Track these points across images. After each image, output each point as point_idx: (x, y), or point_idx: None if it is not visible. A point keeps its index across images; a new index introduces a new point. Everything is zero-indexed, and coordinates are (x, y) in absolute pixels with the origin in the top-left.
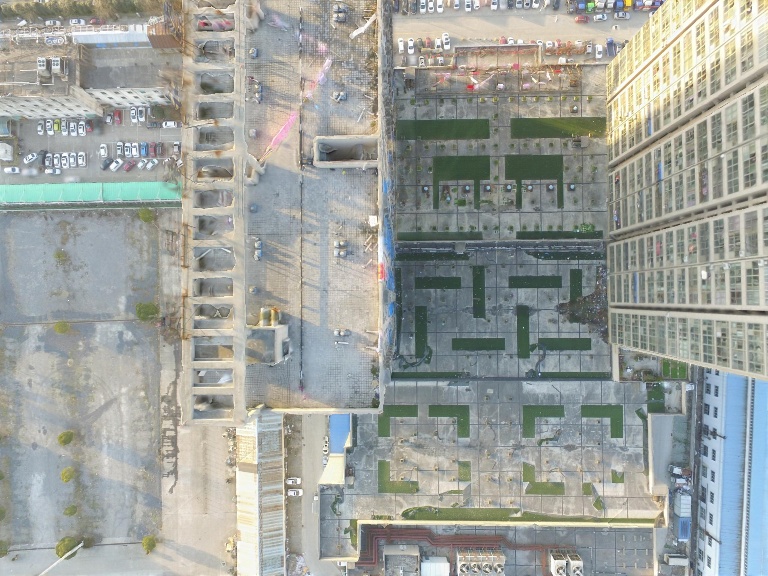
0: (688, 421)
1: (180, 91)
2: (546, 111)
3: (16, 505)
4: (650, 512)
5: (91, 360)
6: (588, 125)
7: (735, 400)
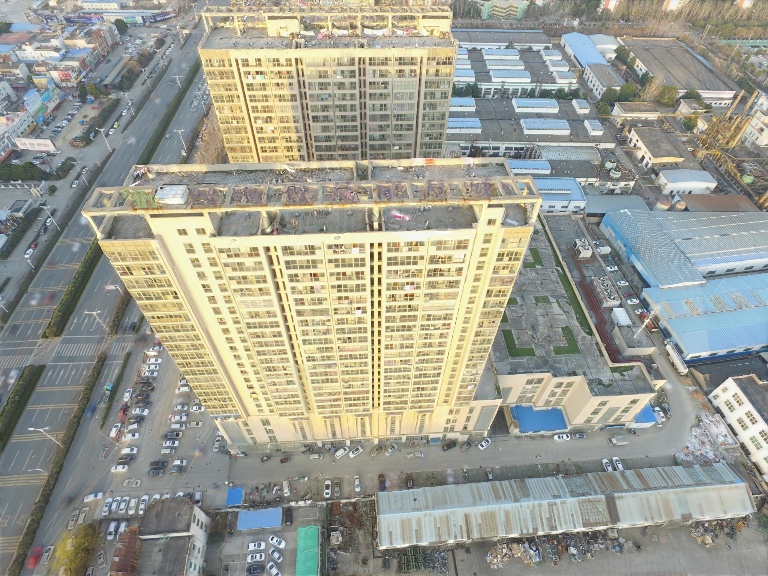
0: None
1: (338, 200)
2: None
3: None
4: None
5: None
6: None
7: None
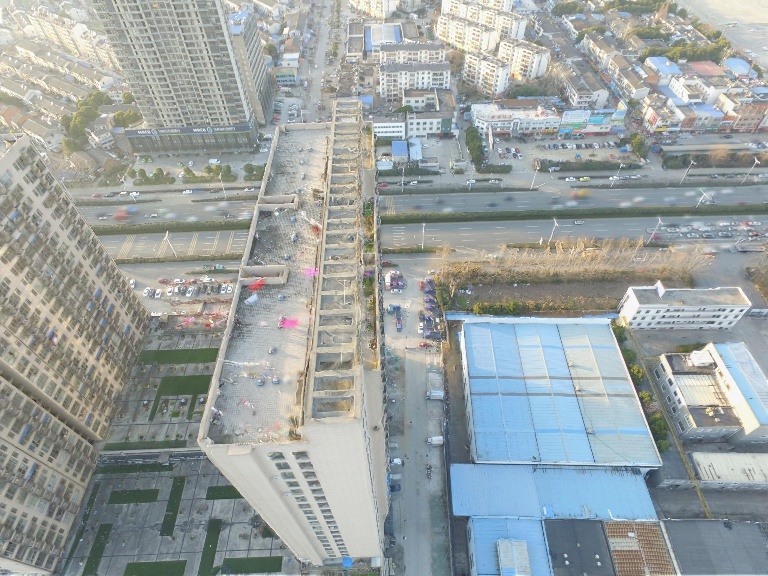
0: None
1: None
2: None
3: None
4: None
5: None
6: None
7: None
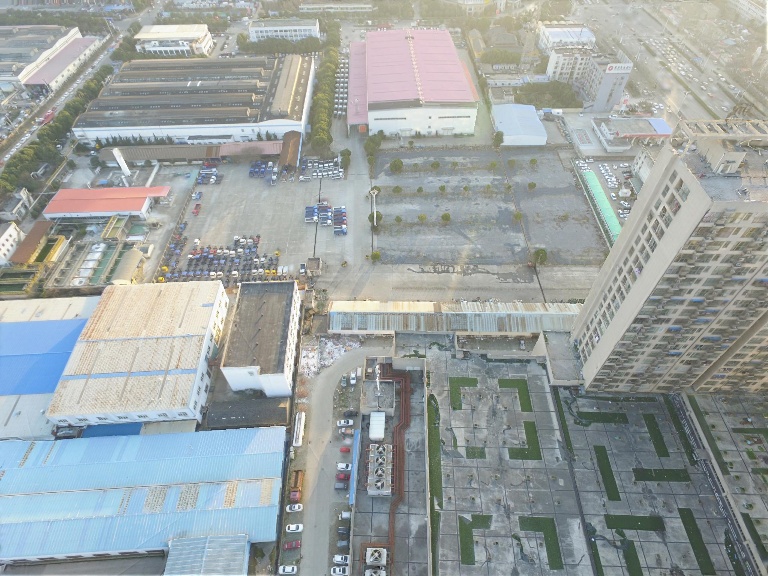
0: None
1: None
2: None
3: (400, 198)
4: None
5: (497, 231)
6: None
7: None
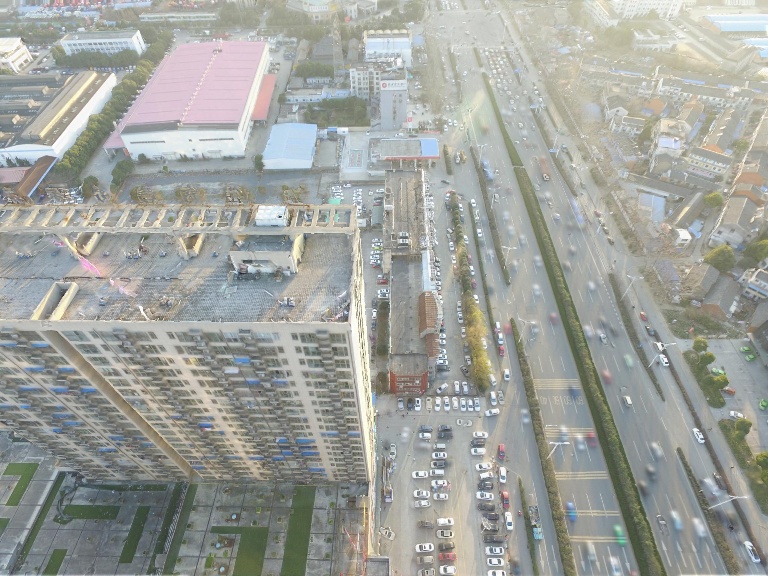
0: None
1: None
2: None
3: None
4: None
5: None
6: None
7: None
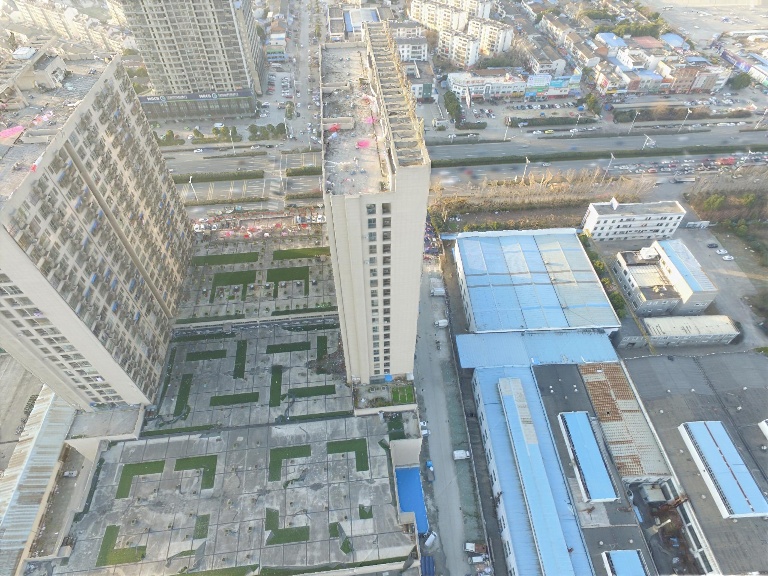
0: (474, 492)
1: None
2: (298, 246)
3: None
4: (402, 548)
5: None
6: (327, 250)
7: (503, 455)
